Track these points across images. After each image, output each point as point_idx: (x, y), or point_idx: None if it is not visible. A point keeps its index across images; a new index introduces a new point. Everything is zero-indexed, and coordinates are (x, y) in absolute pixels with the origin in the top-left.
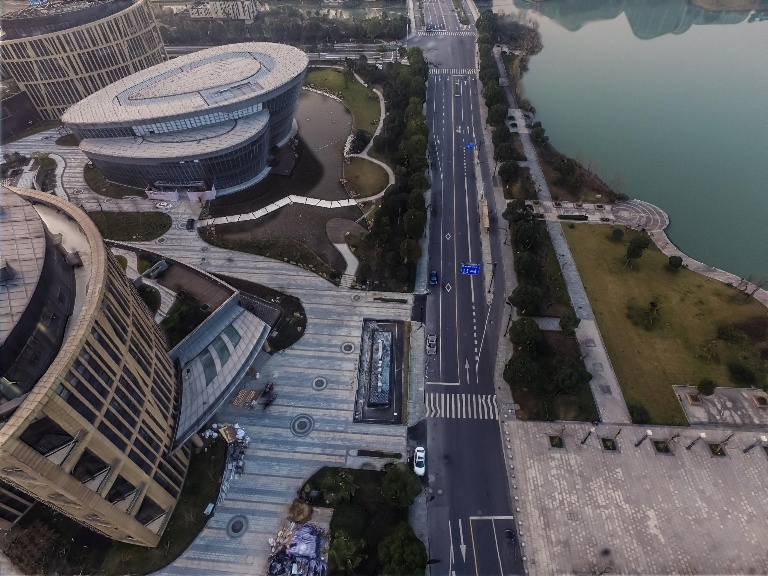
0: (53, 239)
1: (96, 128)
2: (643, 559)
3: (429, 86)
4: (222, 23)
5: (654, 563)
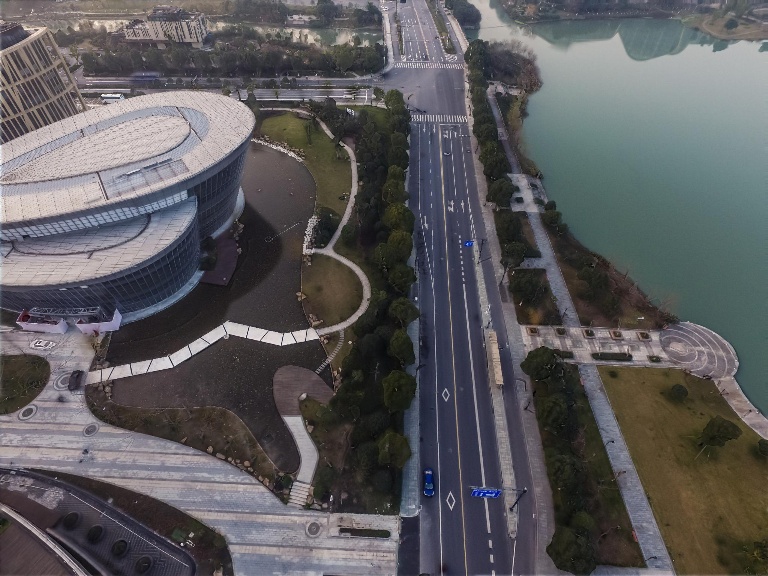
0: None
1: None
2: None
3: (412, 139)
4: (164, 46)
5: None
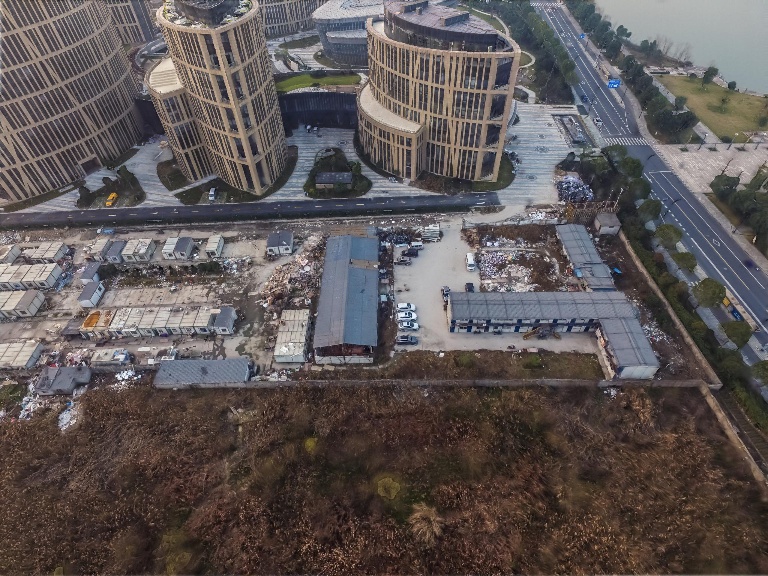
0: None
1: (340, 22)
2: (741, 179)
3: None
4: None
5: (746, 180)
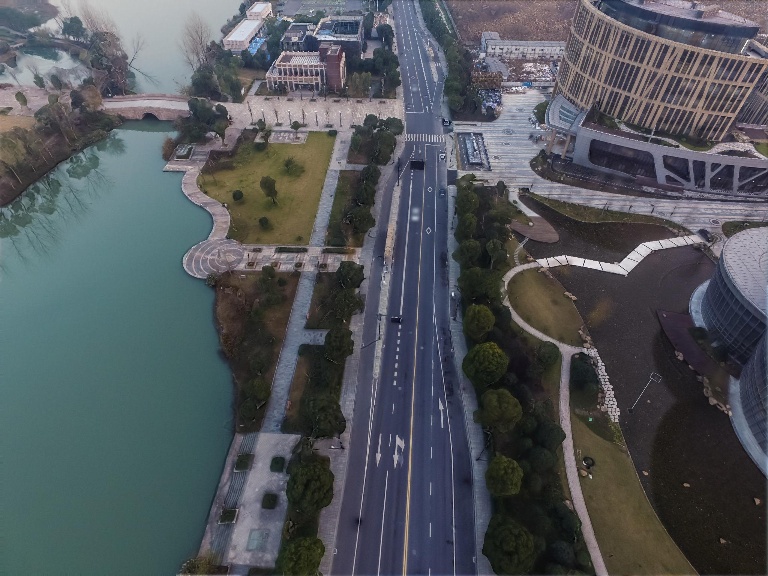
0: (654, 21)
1: None
2: None
3: None
4: None
5: None
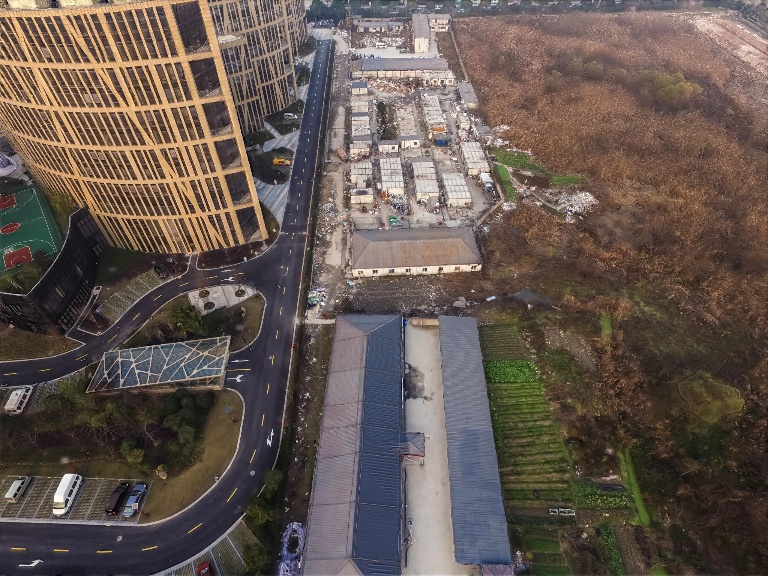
0: None
1: None
2: None
3: None
4: None
5: (323, 0)
